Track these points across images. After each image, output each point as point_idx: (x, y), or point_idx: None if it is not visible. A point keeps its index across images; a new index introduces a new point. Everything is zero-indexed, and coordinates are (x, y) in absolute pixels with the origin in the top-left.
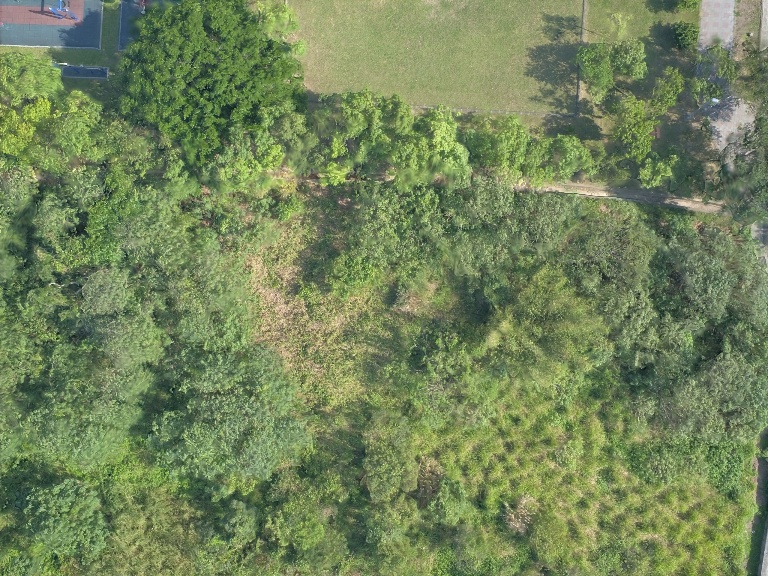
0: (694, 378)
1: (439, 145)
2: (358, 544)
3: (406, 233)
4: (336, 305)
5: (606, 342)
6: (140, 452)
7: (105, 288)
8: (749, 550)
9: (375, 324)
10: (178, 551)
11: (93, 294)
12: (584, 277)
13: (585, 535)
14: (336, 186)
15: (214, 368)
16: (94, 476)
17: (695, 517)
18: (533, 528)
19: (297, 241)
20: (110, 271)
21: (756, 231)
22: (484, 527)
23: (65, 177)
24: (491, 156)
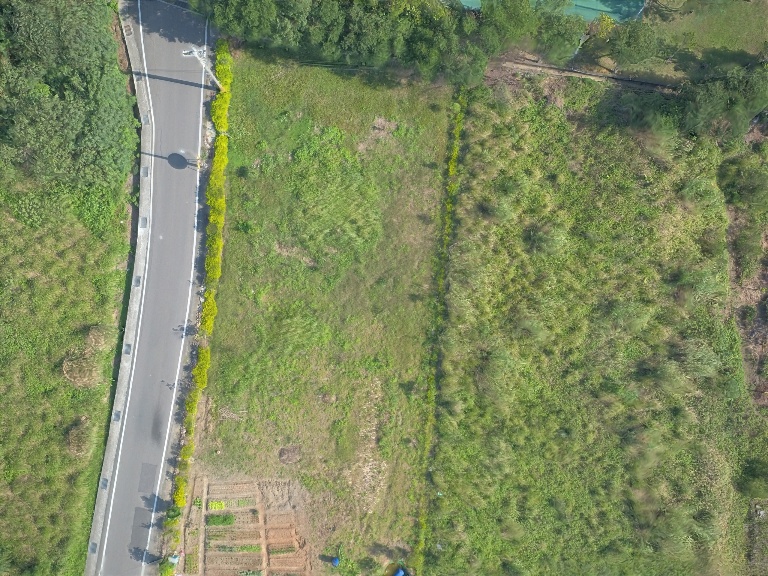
0: (28, 118)
1: None
2: None
3: None
4: None
5: None
6: None
7: None
8: (124, 286)
9: None
10: None
11: None
12: None
13: None
14: None
15: None
16: None
17: (66, 254)
18: None
19: None
20: None
21: (122, 3)
22: None
23: None
24: None
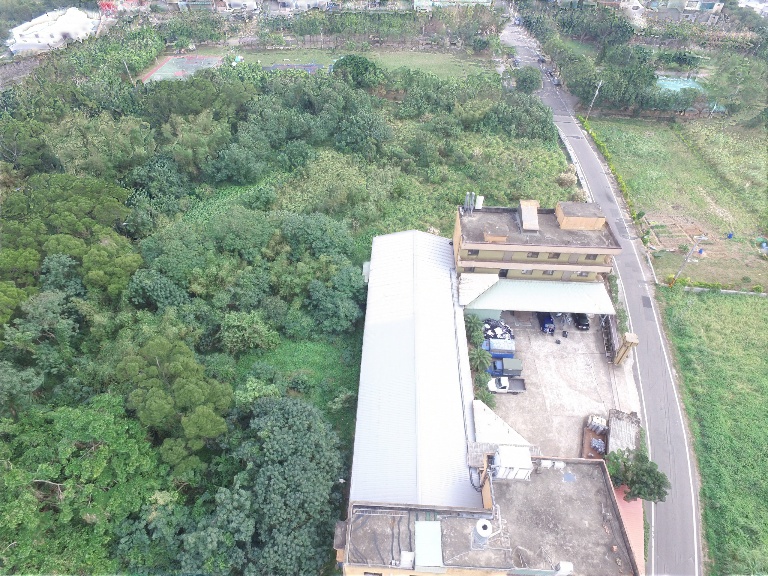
0: None
1: (431, 74)
2: None
3: None
4: None
5: None
6: (328, 148)
7: None
8: None
9: (414, 123)
10: (345, 160)
11: None
12: None
13: None
14: None
15: None
16: None
17: None
18: None
19: None
20: None
21: None
22: None
23: None
24: None
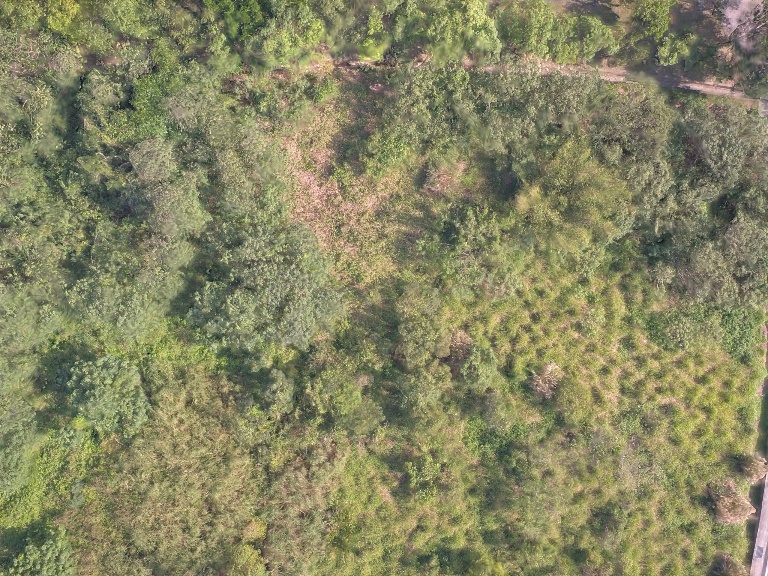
0: (710, 241)
1: (471, 18)
2: (392, 414)
3: (437, 110)
4: (368, 186)
5: (627, 212)
6: (178, 331)
7: (152, 154)
8: (760, 412)
9: (406, 203)
10: (218, 422)
11: (140, 160)
12: (606, 150)
13: (608, 400)
14: (367, 72)
15: (256, 237)
16: (133, 355)
17: (710, 380)
18: (560, 391)
19: (330, 125)
20: (155, 141)
21: (763, 112)
22: (512, 395)
23: (107, 54)
24: (519, 34)
